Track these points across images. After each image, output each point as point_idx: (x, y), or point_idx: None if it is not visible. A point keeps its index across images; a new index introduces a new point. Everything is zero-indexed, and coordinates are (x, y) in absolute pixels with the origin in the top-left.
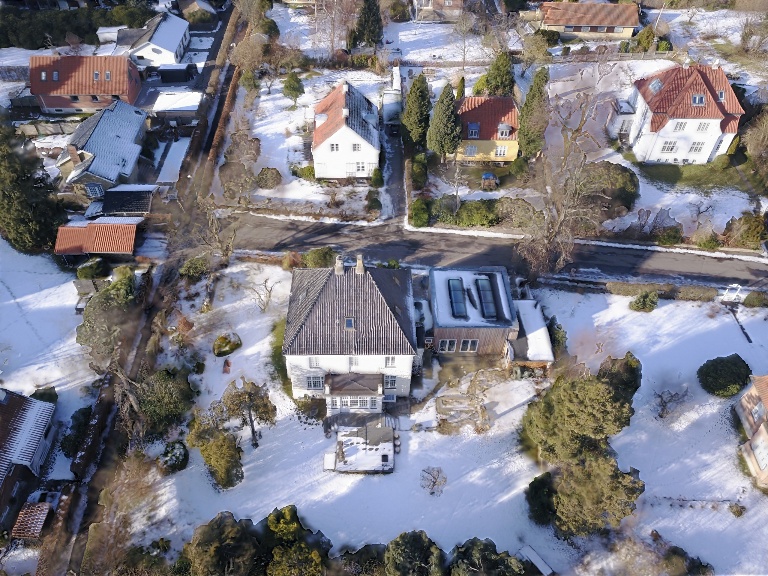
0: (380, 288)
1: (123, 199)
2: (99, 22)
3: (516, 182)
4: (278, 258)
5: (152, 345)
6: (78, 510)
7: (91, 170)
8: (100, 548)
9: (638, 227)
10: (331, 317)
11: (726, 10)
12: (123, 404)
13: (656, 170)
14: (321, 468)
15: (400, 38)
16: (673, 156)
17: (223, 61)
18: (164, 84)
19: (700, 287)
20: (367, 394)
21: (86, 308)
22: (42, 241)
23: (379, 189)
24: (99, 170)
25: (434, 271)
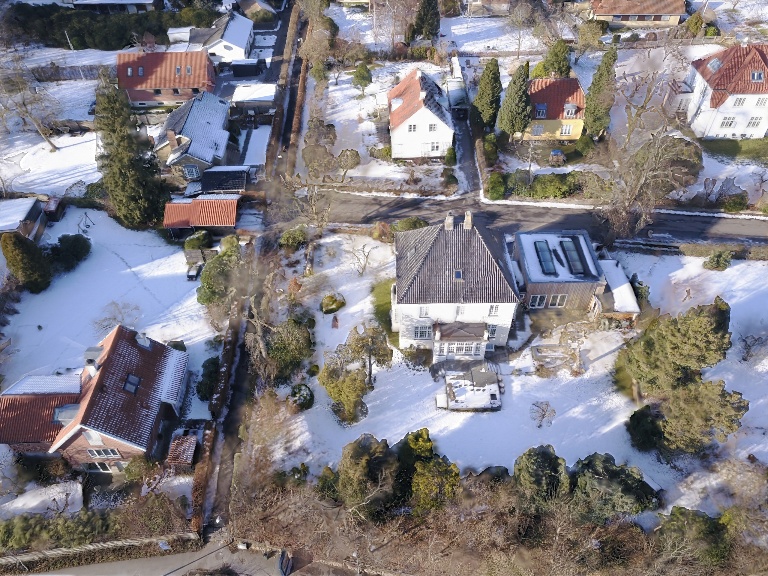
0: (486, 242)
1: (220, 178)
2: (169, 23)
3: (582, 158)
4: (368, 229)
5: (265, 304)
6: (218, 445)
7: (190, 152)
8: (244, 475)
9: (704, 195)
10: (441, 269)
11: None
12: (255, 350)
13: (715, 145)
14: (434, 407)
15: (453, 32)
16: (731, 131)
17: (290, 56)
18: (236, 78)
19: None
20: (474, 340)
21: (202, 272)
22: (148, 218)
23: (453, 167)
24: (196, 152)
25: (520, 235)
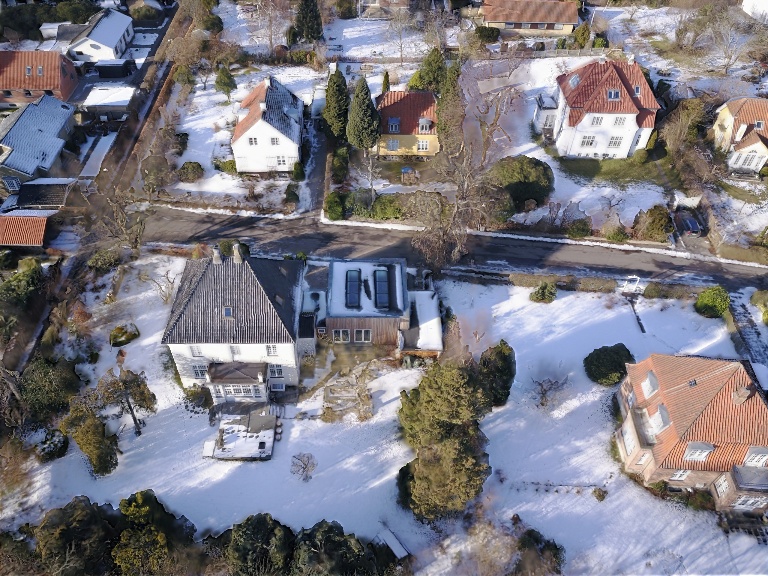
0: (258, 277)
1: (38, 192)
2: (43, 18)
3: (436, 176)
4: (188, 250)
5: (48, 335)
6: None
7: (7, 163)
8: None
9: (549, 220)
10: (210, 306)
11: (668, 7)
12: (3, 392)
13: (576, 164)
14: (201, 455)
15: (344, 35)
16: (593, 151)
17: (162, 57)
18: (102, 79)
19: (600, 278)
20: (248, 382)
21: None
22: None
23: (300, 183)
24: (16, 163)
25: (334, 262)
